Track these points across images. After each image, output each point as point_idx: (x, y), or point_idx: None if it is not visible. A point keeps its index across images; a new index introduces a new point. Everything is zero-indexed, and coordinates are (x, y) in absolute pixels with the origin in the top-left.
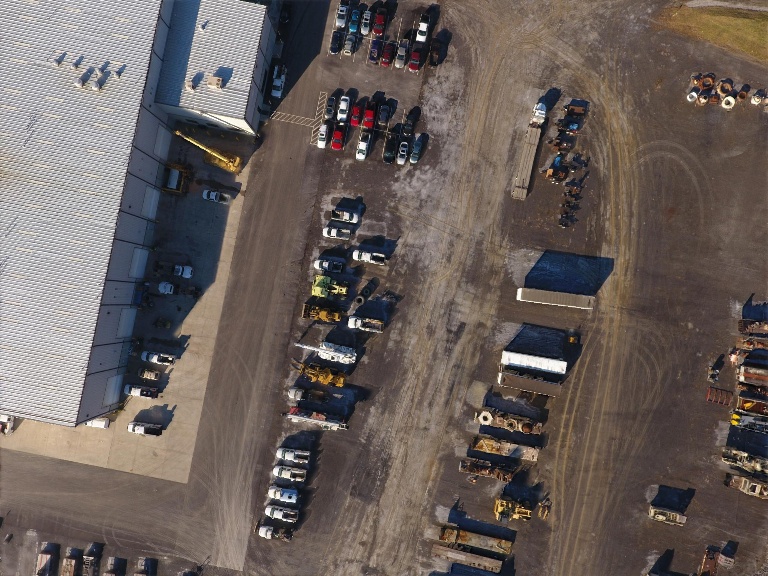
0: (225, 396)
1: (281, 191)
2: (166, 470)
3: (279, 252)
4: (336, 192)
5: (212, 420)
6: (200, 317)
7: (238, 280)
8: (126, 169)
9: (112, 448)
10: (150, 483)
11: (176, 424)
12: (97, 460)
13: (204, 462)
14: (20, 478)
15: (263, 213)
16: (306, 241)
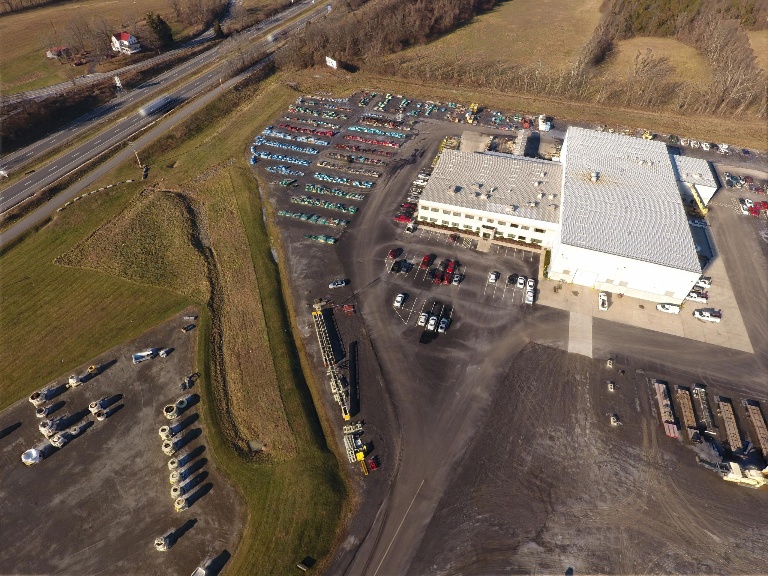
0: (753, 308)
1: (732, 227)
2: (733, 344)
3: (747, 249)
4: (765, 231)
5: (752, 320)
6: (713, 270)
7: (728, 257)
8: (678, 188)
9: (684, 327)
10: (724, 350)
11: (726, 319)
12: (676, 332)
13: (760, 342)
14: (619, 336)
15: (726, 234)
16: (761, 247)
